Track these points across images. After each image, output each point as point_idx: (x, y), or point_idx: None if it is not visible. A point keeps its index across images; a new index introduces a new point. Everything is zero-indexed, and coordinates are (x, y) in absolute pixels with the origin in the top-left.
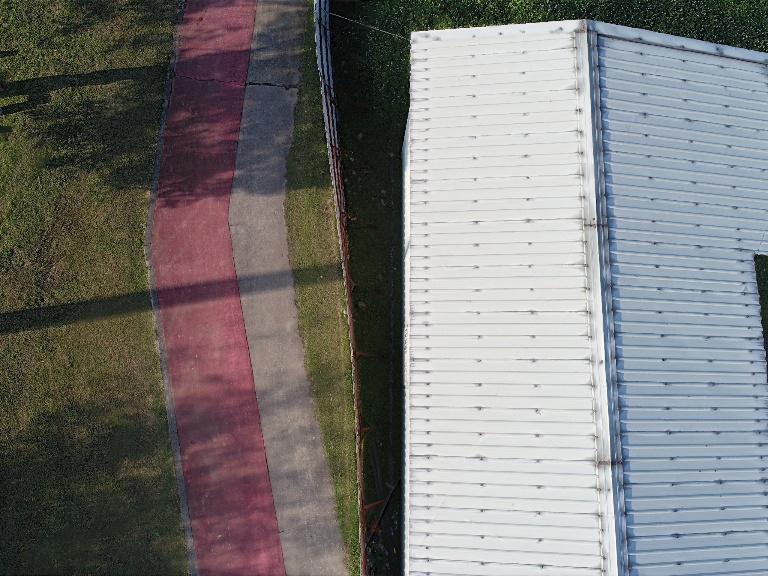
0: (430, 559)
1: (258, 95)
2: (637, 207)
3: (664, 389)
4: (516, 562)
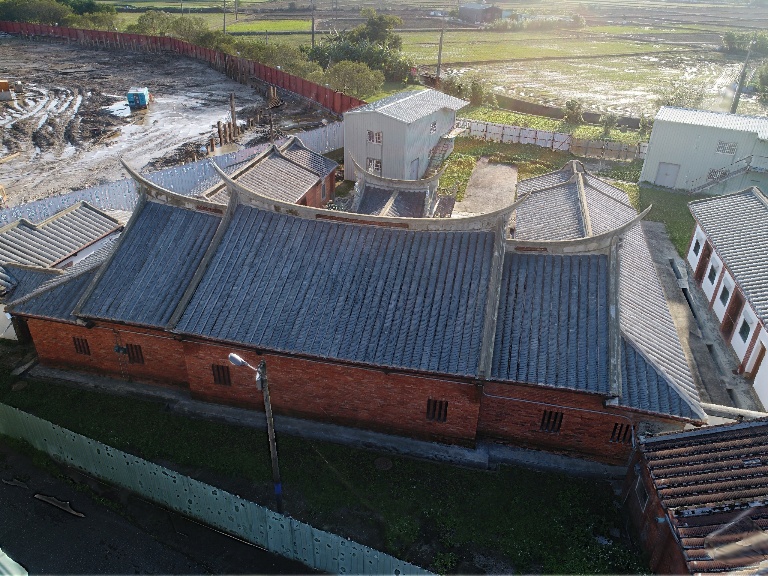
0: None
1: None
2: None
3: (726, 118)
4: None
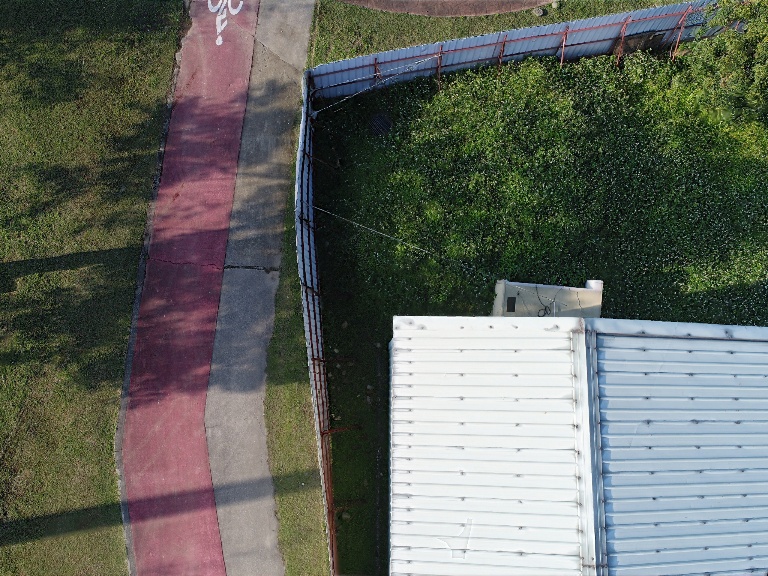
0: None
1: (237, 279)
2: (640, 537)
3: None
4: None
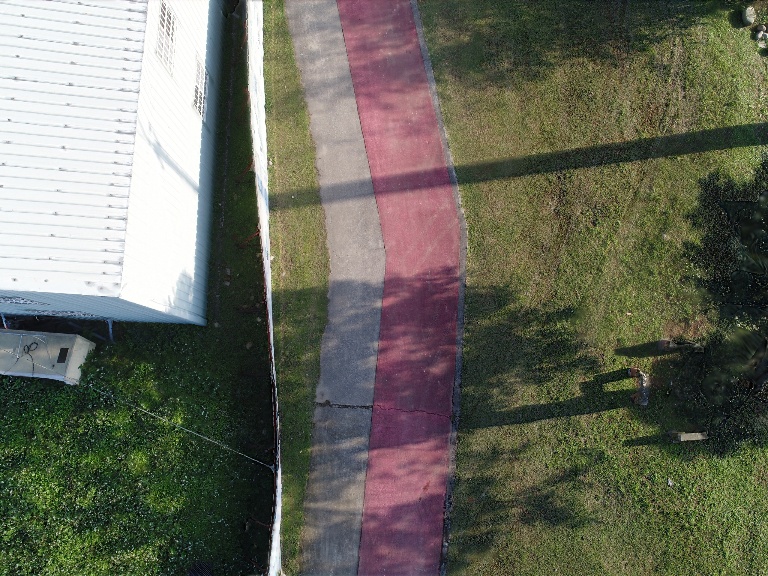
0: None
1: (359, 394)
2: None
3: None
4: None
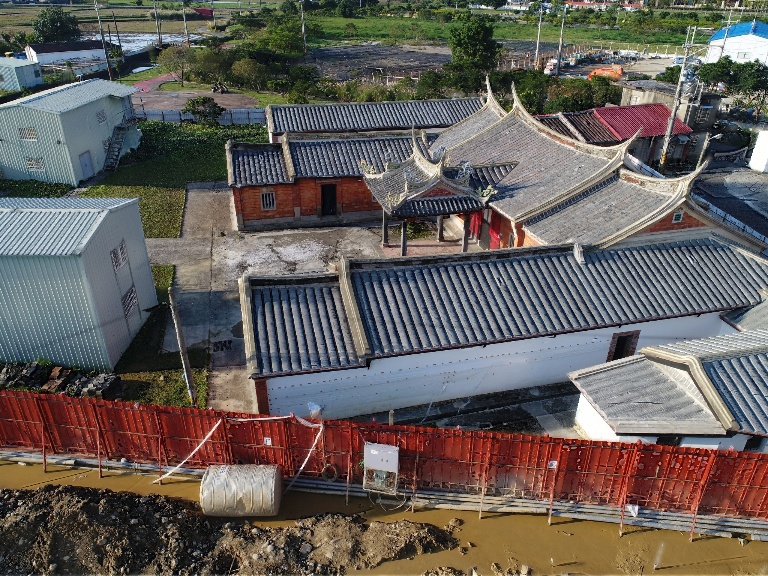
0: None
1: None
2: None
3: None
4: None
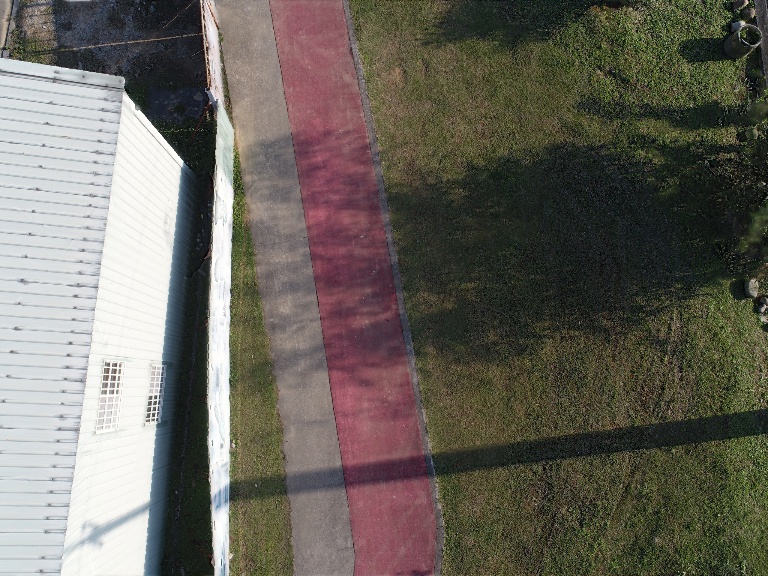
0: (89, 196)
1: None
2: None
3: None
4: (4, 188)
